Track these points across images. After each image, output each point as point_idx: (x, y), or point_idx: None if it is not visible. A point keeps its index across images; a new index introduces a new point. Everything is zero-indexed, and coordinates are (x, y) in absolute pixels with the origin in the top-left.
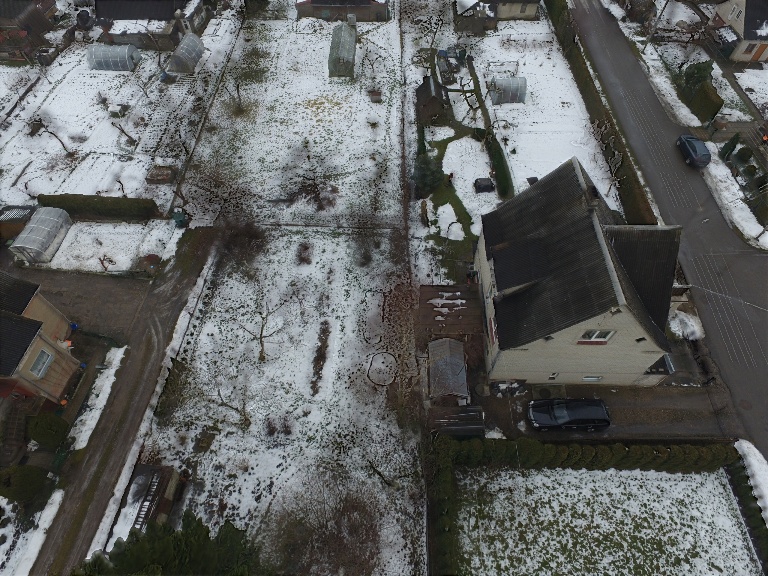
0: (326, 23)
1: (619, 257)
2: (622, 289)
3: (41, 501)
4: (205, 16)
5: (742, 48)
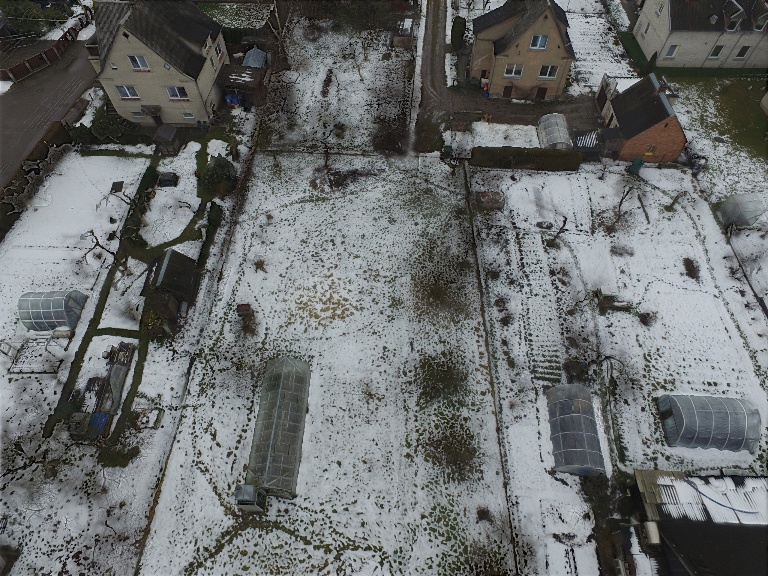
0: None
1: None
2: None
3: None
4: None
5: None
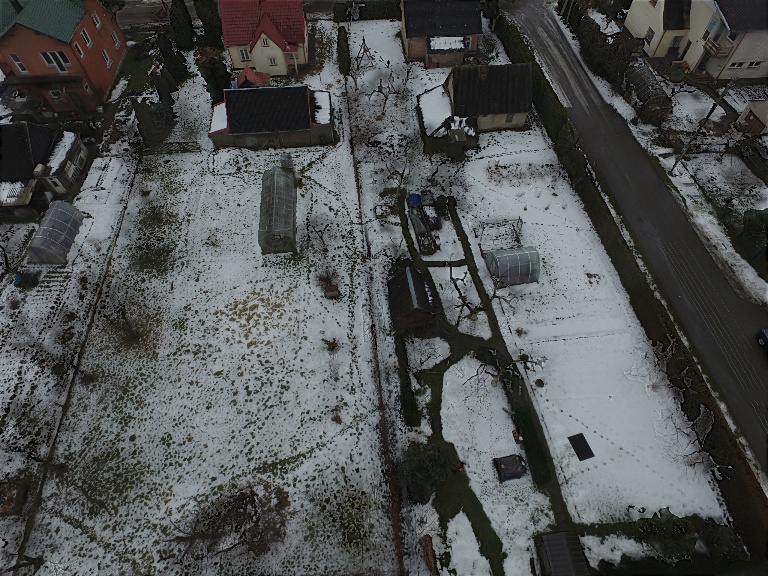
0: (253, 154)
1: None
2: None
3: None
4: (86, 155)
5: None
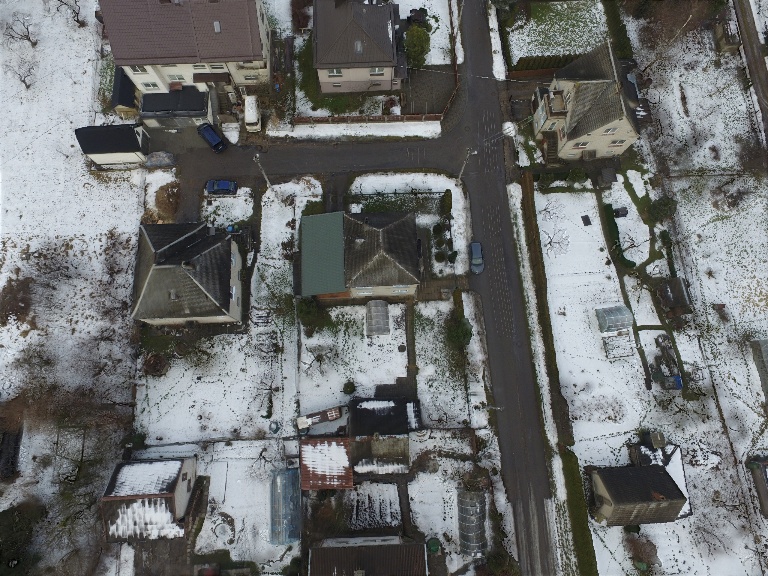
0: None
1: None
2: None
3: (767, 40)
4: None
5: None
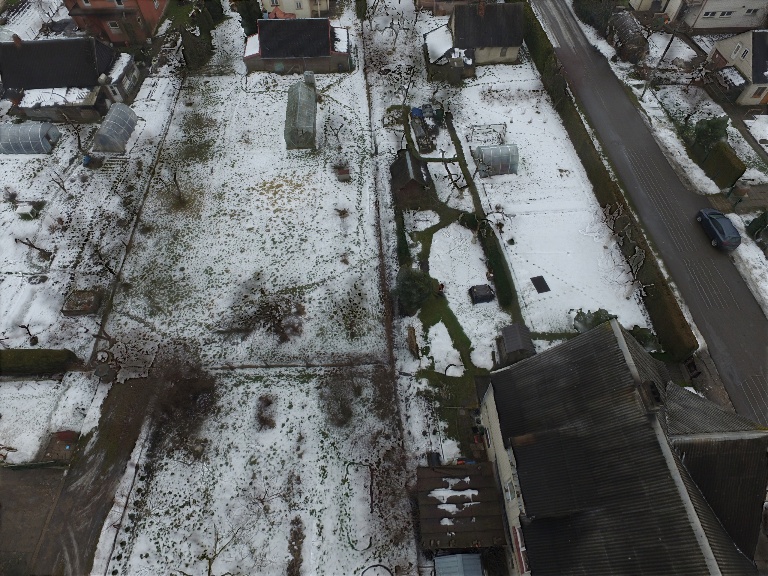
0: (280, 77)
1: (692, 475)
2: (721, 570)
3: None
4: (138, 75)
5: (751, 92)
